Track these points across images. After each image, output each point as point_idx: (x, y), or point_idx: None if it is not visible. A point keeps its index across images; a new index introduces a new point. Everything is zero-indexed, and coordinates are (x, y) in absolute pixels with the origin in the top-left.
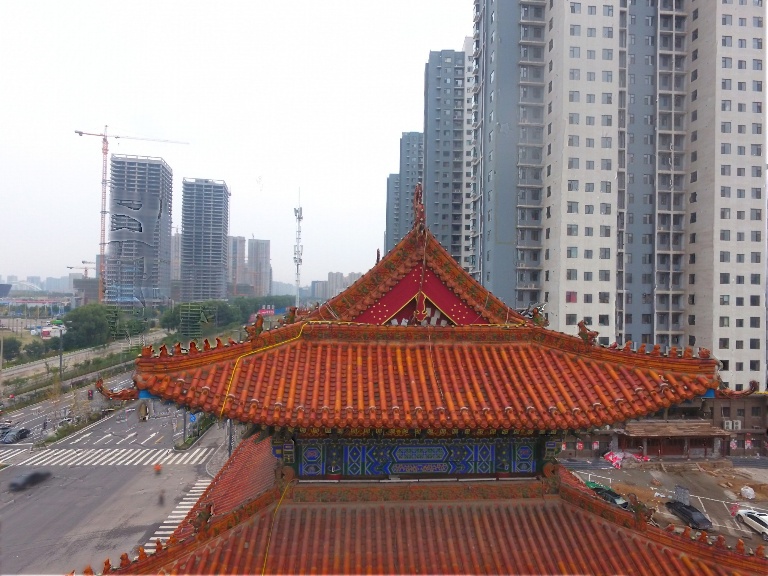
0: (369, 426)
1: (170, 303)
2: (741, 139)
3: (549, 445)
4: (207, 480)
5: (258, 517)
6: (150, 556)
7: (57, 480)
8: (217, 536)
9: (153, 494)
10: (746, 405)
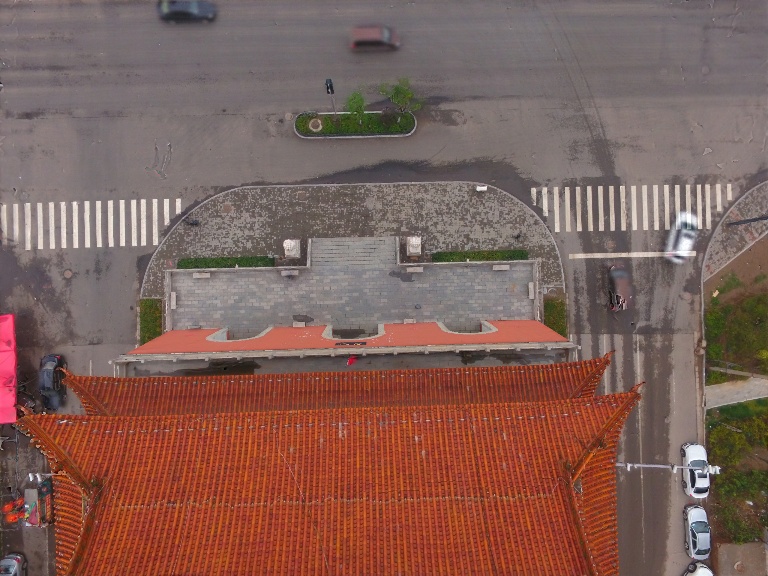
0: None
1: None
2: None
3: None
4: (730, 195)
5: None
6: None
7: (730, 4)
8: None
9: (688, 144)
10: None
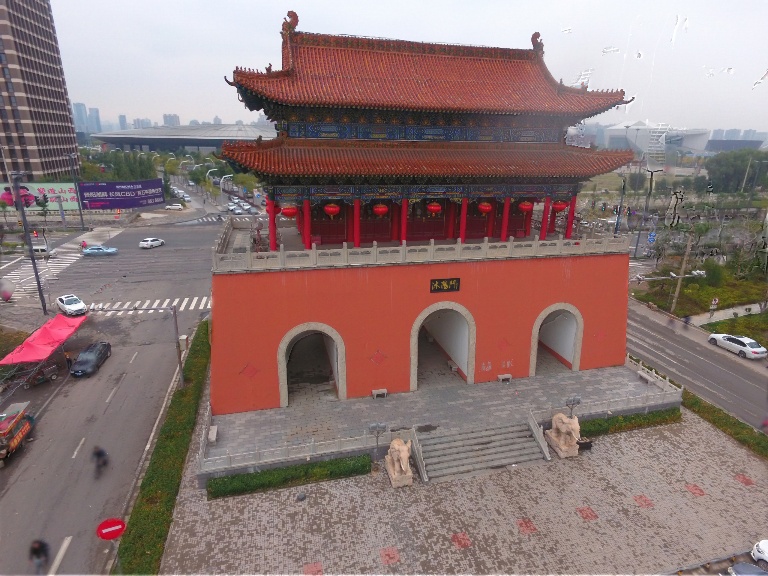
0: None
1: (648, 126)
2: None
3: None
4: None
5: None
6: None
7: None
8: None
9: None
10: None
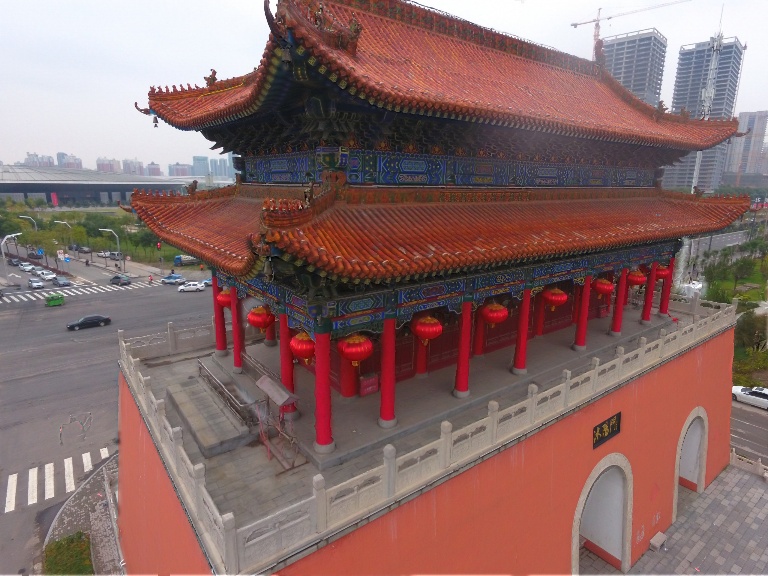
0: (198, 122)
1: None
2: None
3: (317, 150)
4: None
5: (223, 200)
6: (168, 196)
7: None
8: (200, 200)
9: None
10: None
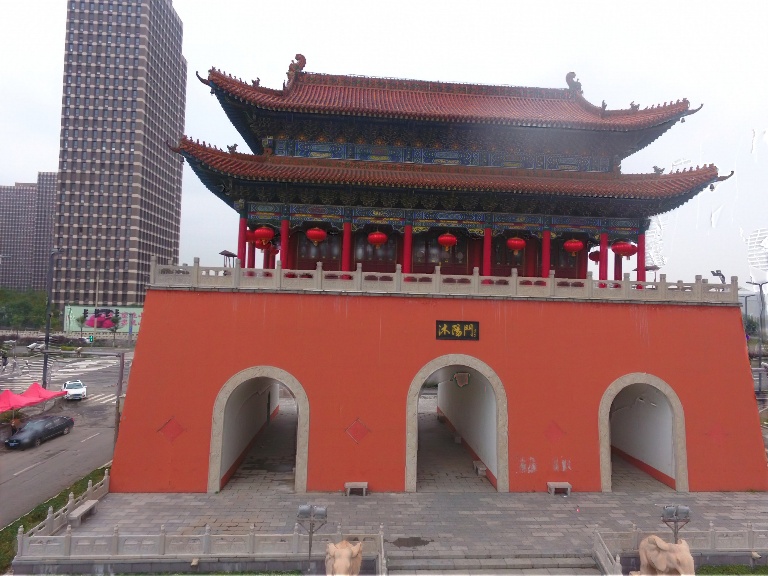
0: None
1: (744, 235)
2: None
3: None
4: None
5: None
6: None
7: None
8: None
9: None
10: None
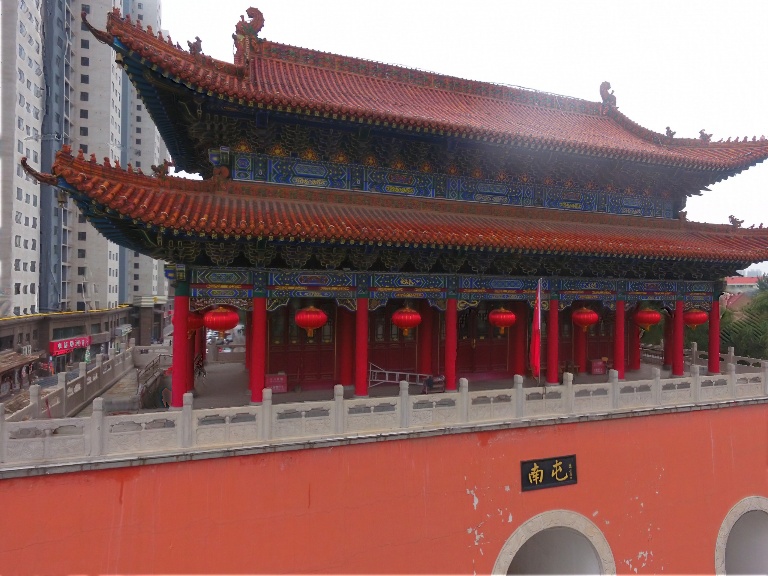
0: None
1: None
2: (31, 50)
3: None
4: None
5: None
6: (765, 229)
7: None
8: None
9: None
10: (31, 329)
